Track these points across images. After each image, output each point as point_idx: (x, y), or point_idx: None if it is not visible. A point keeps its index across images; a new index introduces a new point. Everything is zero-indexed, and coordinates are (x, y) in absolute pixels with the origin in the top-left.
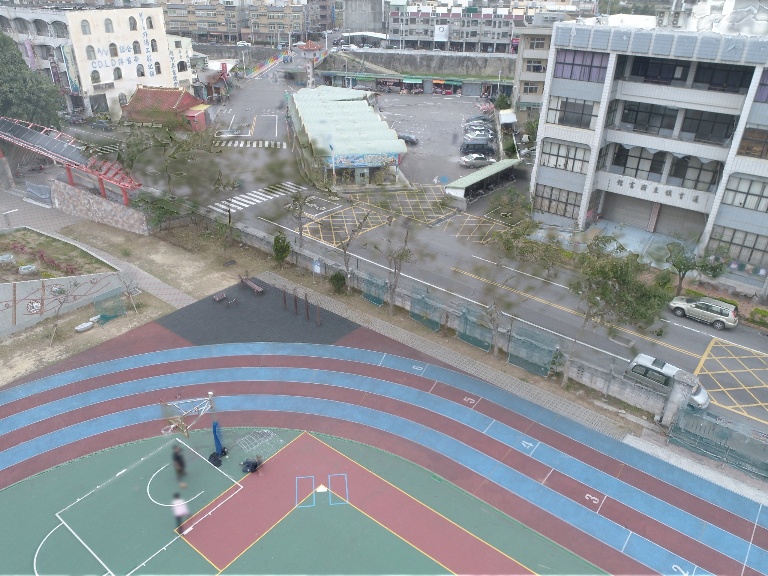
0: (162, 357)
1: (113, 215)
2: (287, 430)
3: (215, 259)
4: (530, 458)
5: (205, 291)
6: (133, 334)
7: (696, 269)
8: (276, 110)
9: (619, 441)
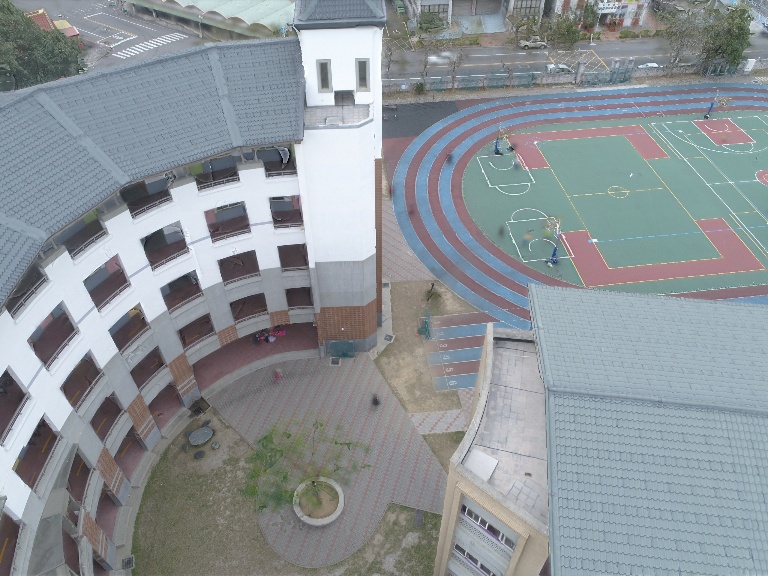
0: (417, 145)
1: None
2: None
3: None
4: None
5: None
6: (386, 146)
7: None
8: (86, 8)
9: (576, 92)
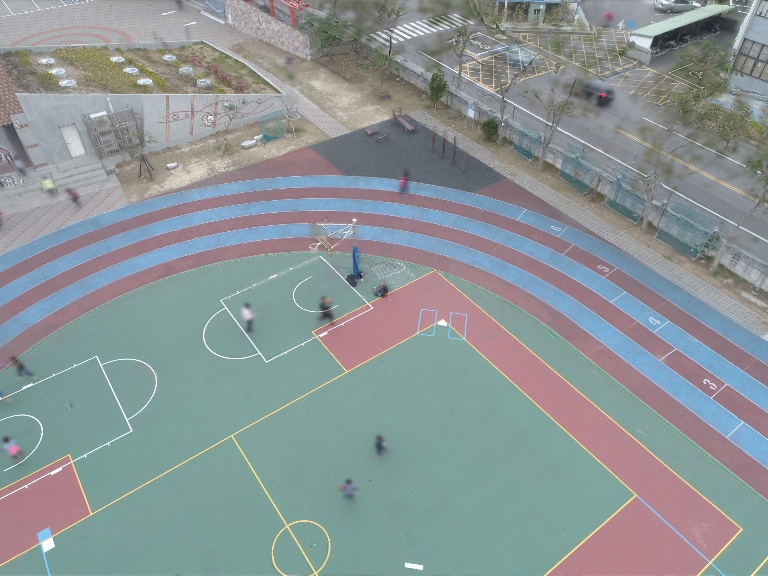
0: (314, 181)
1: (280, 36)
2: (419, 266)
3: (371, 91)
4: (654, 334)
5: (358, 123)
6: (290, 156)
7: None
8: None
9: (758, 336)
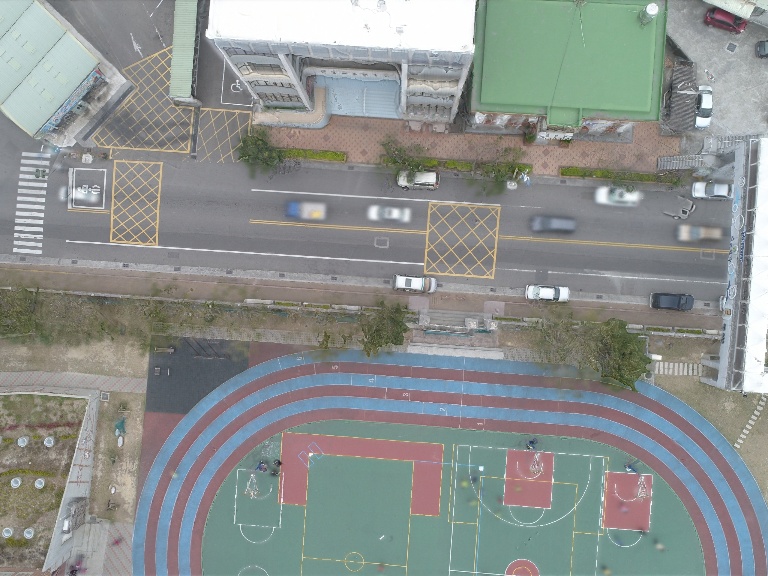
0: (181, 433)
1: None
2: (275, 436)
3: (109, 331)
4: (376, 388)
5: (141, 368)
6: (148, 428)
7: (407, 166)
8: None
9: (406, 353)
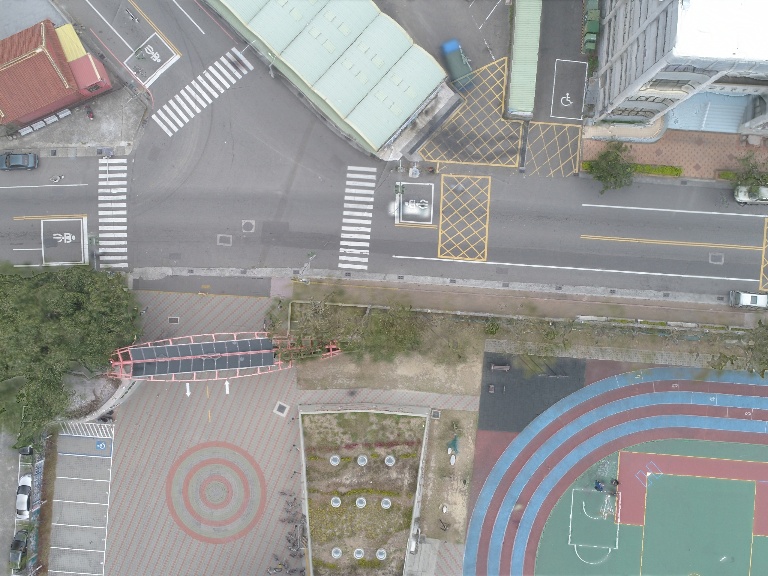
0: (514, 452)
1: None
2: (611, 455)
3: (441, 348)
4: (717, 407)
5: (473, 386)
6: (480, 446)
7: (761, 182)
8: None
9: None
